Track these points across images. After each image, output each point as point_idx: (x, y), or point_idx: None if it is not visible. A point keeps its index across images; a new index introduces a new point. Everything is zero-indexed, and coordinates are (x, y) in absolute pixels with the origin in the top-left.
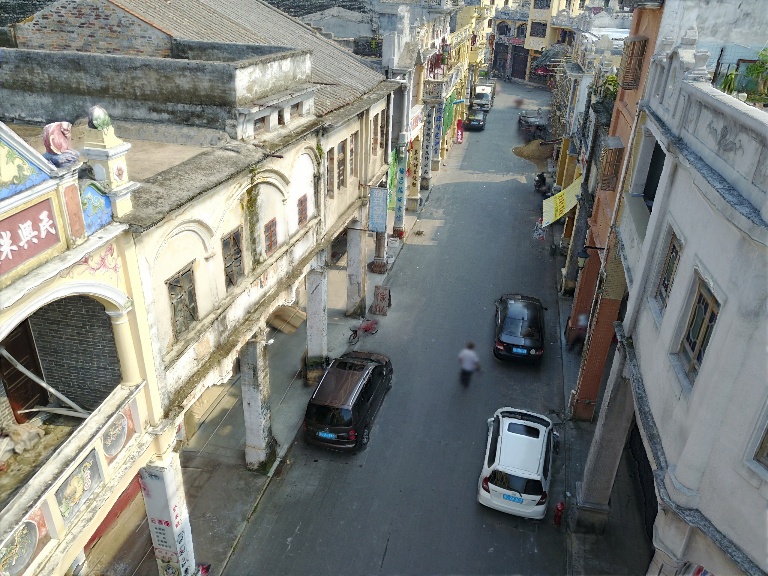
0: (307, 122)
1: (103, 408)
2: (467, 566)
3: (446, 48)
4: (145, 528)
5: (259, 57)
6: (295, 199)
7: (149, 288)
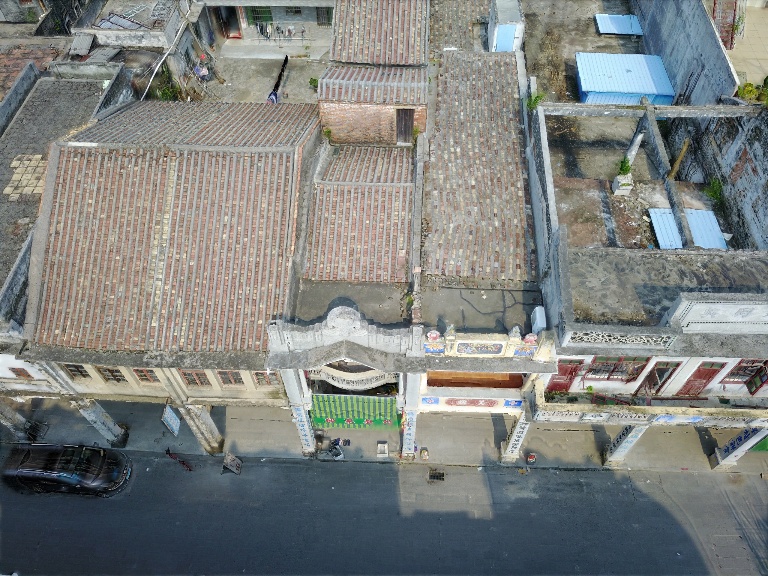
0: None
1: None
2: None
3: (764, 375)
4: None
5: None
6: (2, 366)
7: None
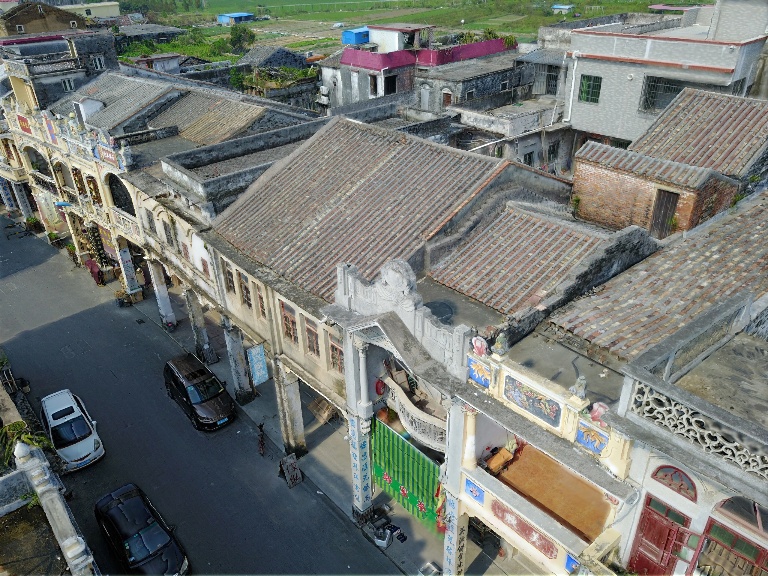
0: (199, 220)
1: (136, 219)
2: (74, 393)
3: None
4: (215, 324)
5: (173, 163)
6: None
7: (136, 200)
